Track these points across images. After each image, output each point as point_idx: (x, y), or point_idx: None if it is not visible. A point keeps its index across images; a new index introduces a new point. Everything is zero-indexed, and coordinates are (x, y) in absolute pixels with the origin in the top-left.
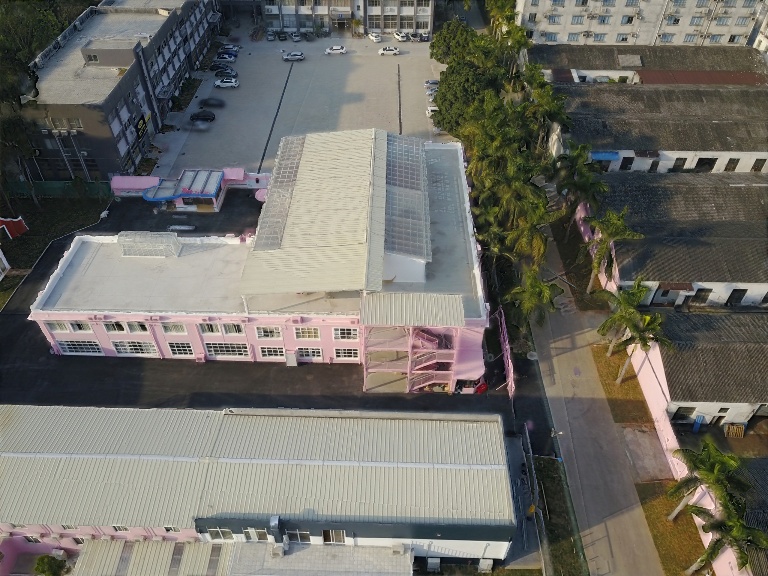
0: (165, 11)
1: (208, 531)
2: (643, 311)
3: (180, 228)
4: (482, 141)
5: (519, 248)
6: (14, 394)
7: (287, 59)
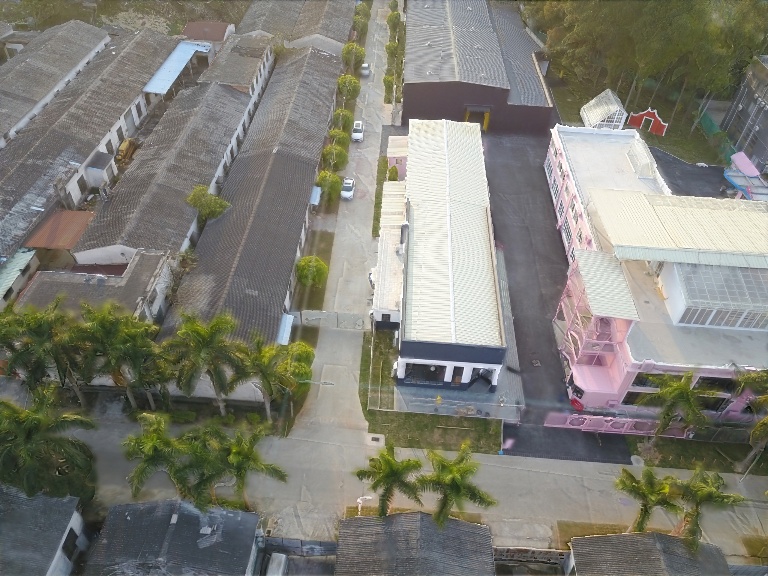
0: None
1: None
2: None
3: None
4: None
5: (762, 399)
6: (508, 155)
7: None
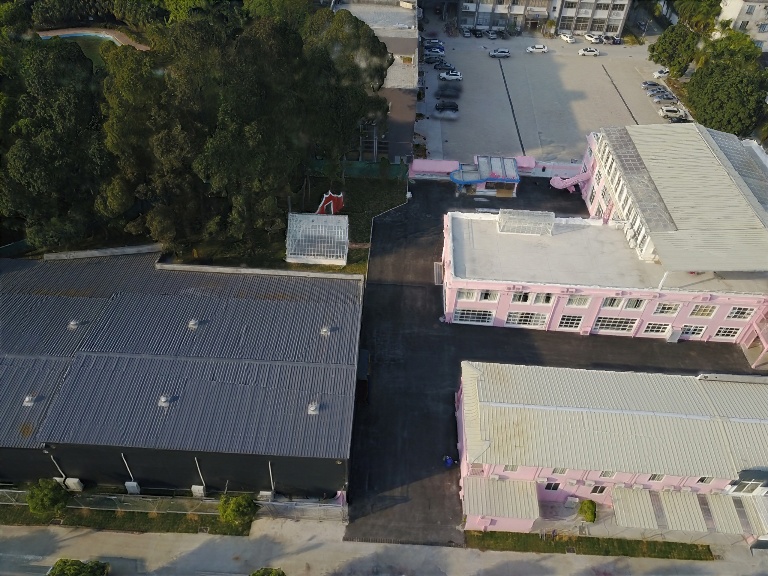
0: (409, 4)
1: (739, 483)
2: None
3: (489, 211)
4: None
5: None
6: (430, 357)
7: (494, 55)
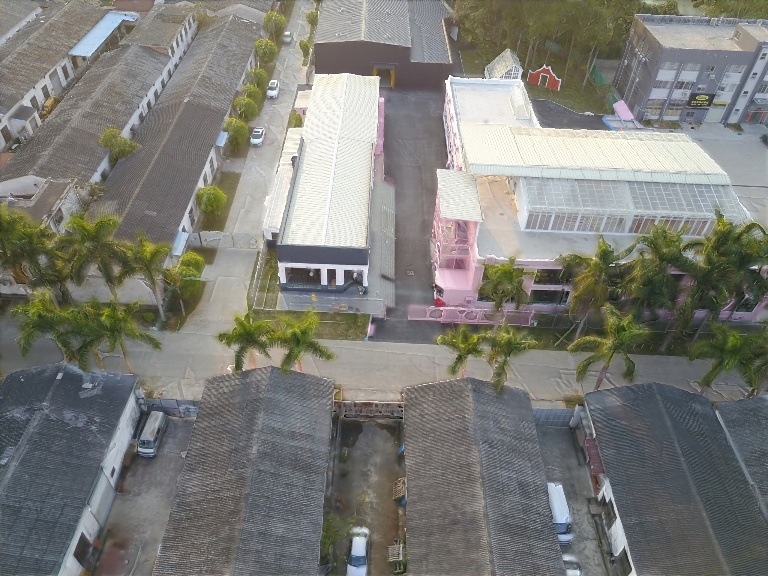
0: None
1: None
2: (578, 458)
3: None
4: None
5: (578, 279)
6: (411, 108)
7: None
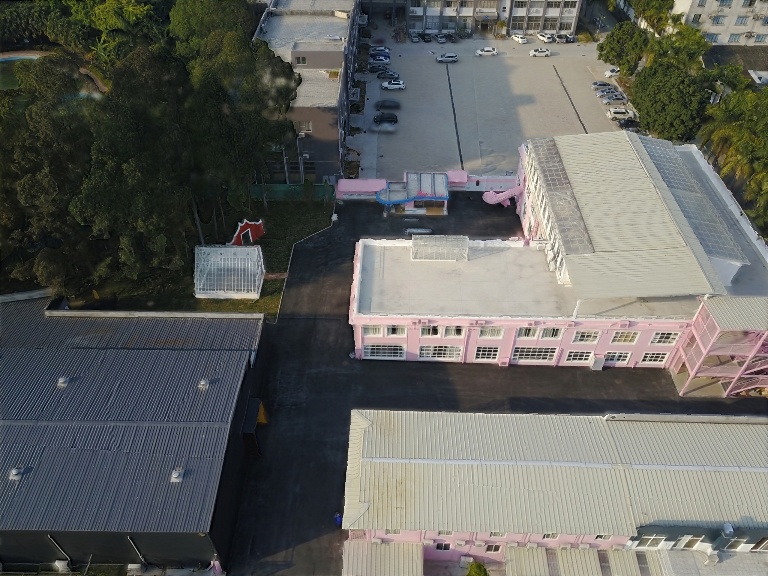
0: (343, 13)
1: (640, 539)
2: None
3: (417, 231)
4: (749, 143)
5: None
6: (334, 399)
7: (441, 61)
